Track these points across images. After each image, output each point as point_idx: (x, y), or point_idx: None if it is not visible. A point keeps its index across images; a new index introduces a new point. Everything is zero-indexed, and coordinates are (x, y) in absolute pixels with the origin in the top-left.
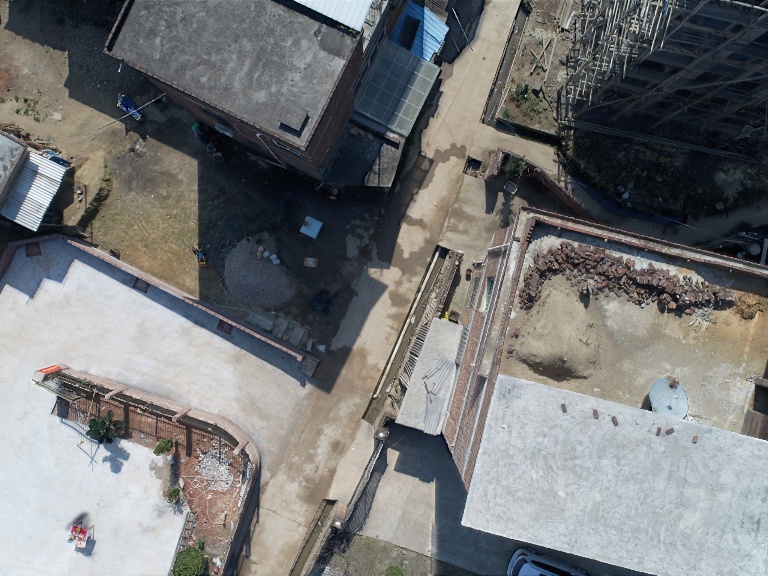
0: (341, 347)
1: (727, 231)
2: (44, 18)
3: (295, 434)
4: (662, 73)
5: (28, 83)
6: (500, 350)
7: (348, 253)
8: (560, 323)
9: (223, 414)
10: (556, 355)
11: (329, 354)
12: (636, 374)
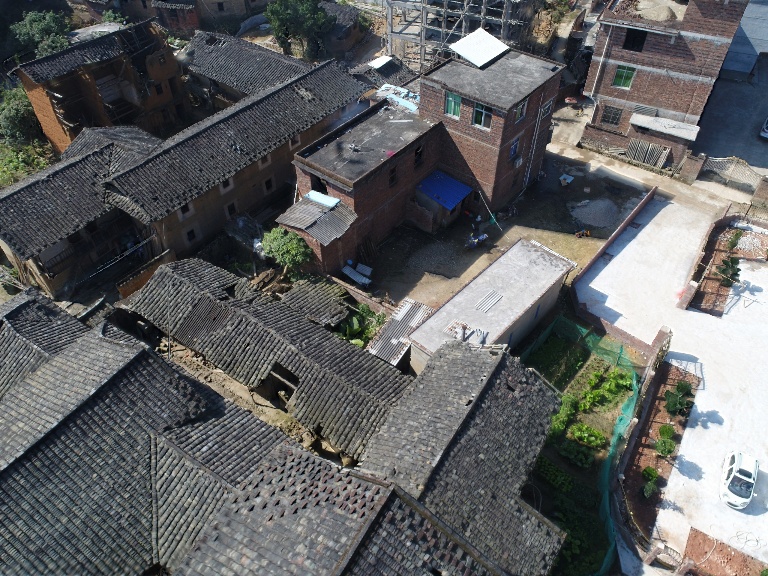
0: (643, 187)
1: (569, 72)
2: (397, 280)
3: None
4: None
5: (444, 298)
6: (667, 19)
7: (581, 175)
8: (652, 8)
9: (700, 237)
10: (668, 8)
11: (648, 192)
12: (670, 5)
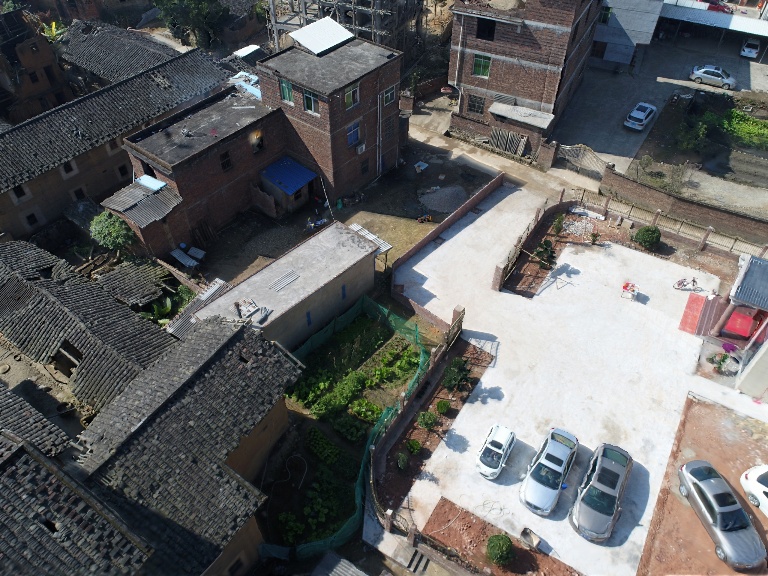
0: (498, 174)
1: None
2: (229, 263)
3: (554, 199)
4: (392, 23)
5: None
6: (511, 8)
7: (440, 163)
8: None
9: None
10: None
11: None
12: None
